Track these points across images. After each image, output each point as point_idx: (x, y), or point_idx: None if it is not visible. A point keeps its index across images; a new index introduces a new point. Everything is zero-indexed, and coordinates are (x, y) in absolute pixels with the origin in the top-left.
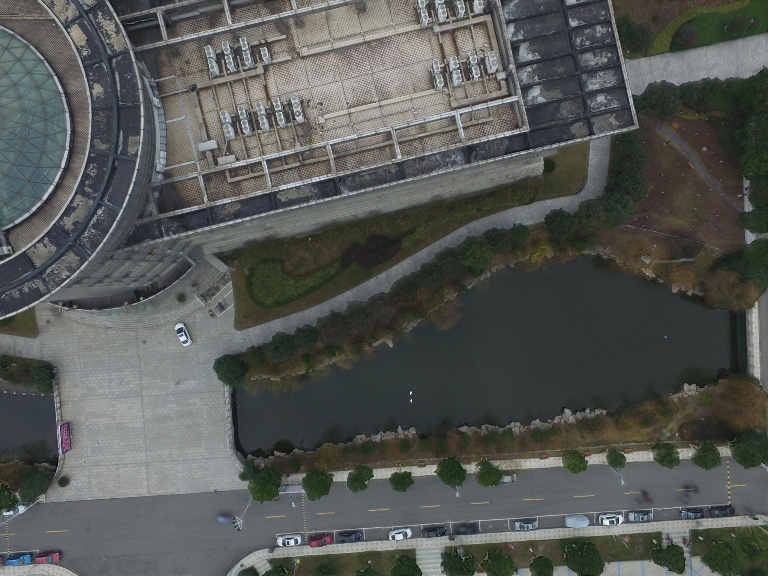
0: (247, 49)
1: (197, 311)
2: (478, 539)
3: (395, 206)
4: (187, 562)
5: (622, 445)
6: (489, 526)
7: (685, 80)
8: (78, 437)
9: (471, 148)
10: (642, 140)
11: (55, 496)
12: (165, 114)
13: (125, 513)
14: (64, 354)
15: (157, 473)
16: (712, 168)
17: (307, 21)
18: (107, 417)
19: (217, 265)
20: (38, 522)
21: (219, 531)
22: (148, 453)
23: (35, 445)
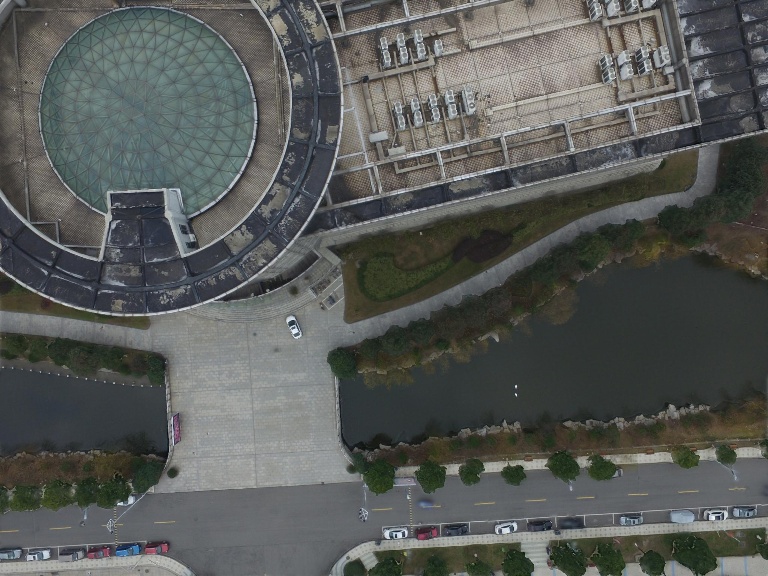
0: (422, 41)
1: (308, 304)
2: (583, 533)
3: (508, 201)
4: (293, 554)
5: (728, 441)
6: (594, 521)
7: None
8: (187, 428)
9: (642, 141)
10: None
11: (163, 487)
12: None
13: (233, 505)
14: (175, 346)
15: (265, 465)
16: None
17: (476, 14)
18: (216, 409)
19: (331, 258)
20: (146, 513)
21: (326, 523)
22: (257, 445)
23: (135, 437)
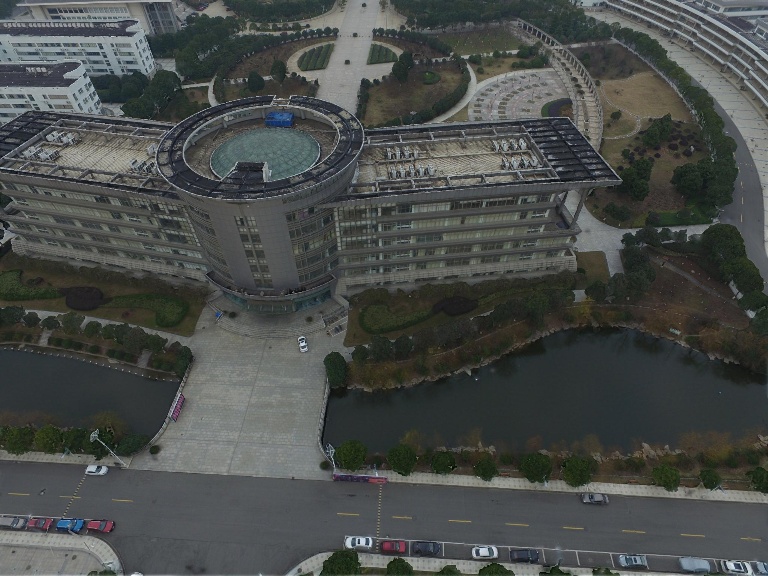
0: None
1: (317, 331)
2: (578, 574)
3: (473, 280)
4: (240, 557)
5: None
6: (589, 560)
7: None
8: (186, 413)
9: None
10: None
11: (139, 464)
12: (360, 170)
13: (197, 490)
14: (205, 350)
15: (243, 453)
16: (704, 282)
17: (437, 149)
18: (218, 399)
19: (342, 301)
20: (110, 488)
21: (285, 524)
22: (242, 433)
23: None
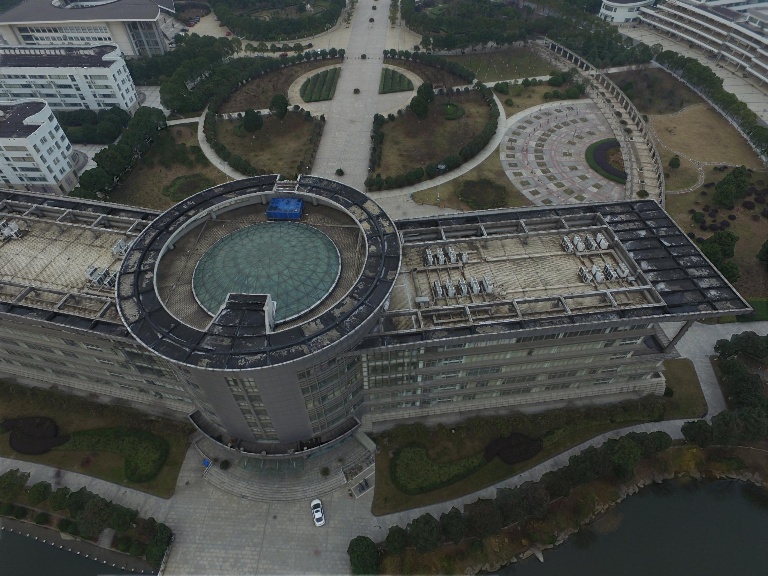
0: None
1: (336, 489)
2: None
3: (533, 408)
4: None
5: None
6: None
7: None
8: None
9: (624, 313)
10: None
11: None
12: None
13: None
14: (189, 521)
15: None
16: None
17: (489, 246)
18: None
19: (366, 442)
20: None
21: None
22: None
23: None
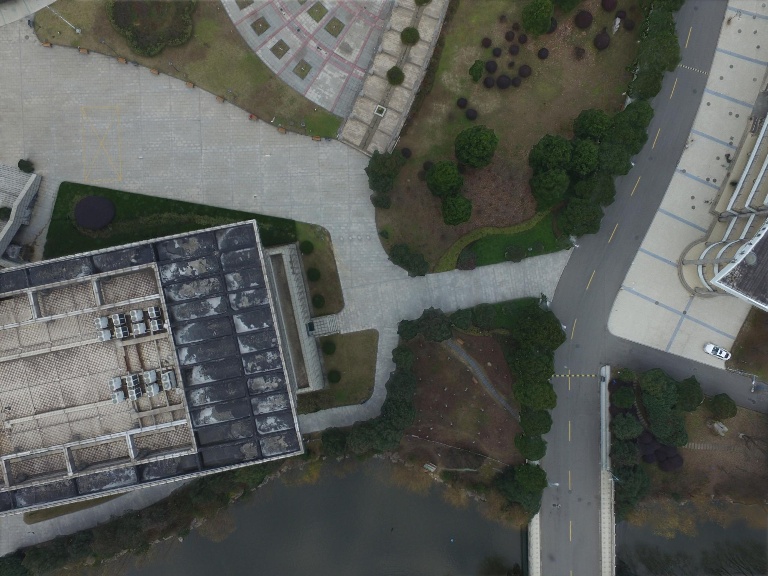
0: None
1: None
2: None
3: None
4: None
5: None
6: None
7: (472, 296)
8: None
9: (144, 464)
10: (428, 354)
11: None
12: None
13: None
14: None
15: None
16: (497, 383)
17: None
18: None
19: None
20: None
21: None
22: None
23: None
